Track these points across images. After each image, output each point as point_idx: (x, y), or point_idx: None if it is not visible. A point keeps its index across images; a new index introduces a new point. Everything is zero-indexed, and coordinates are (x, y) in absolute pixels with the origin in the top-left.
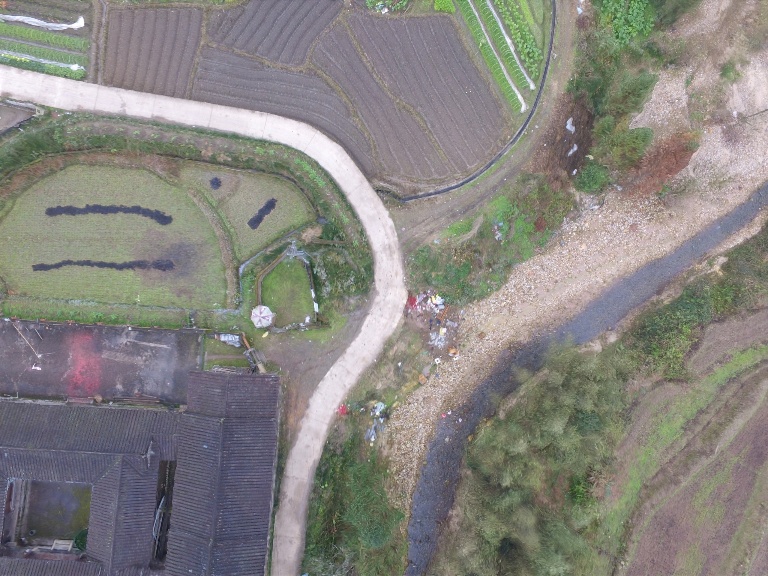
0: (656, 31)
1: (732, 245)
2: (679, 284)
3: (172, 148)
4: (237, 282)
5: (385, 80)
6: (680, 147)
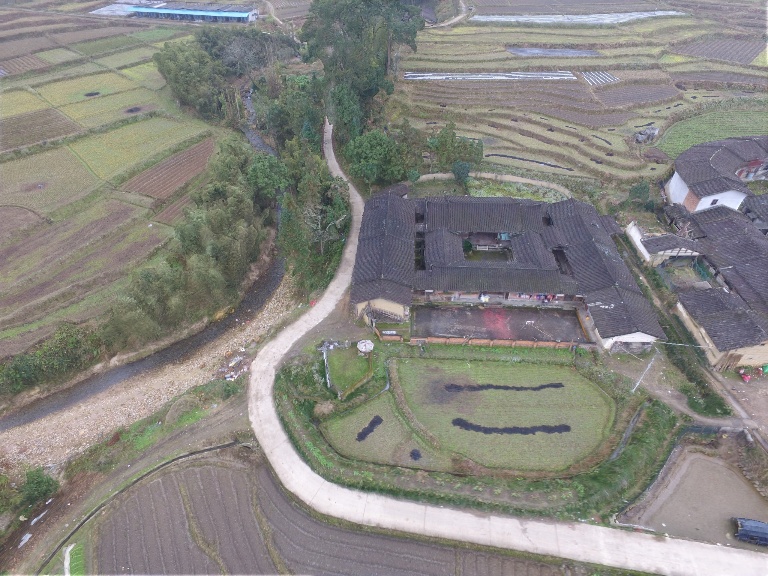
0: None
1: None
2: (15, 405)
3: None
4: None
5: None
6: None
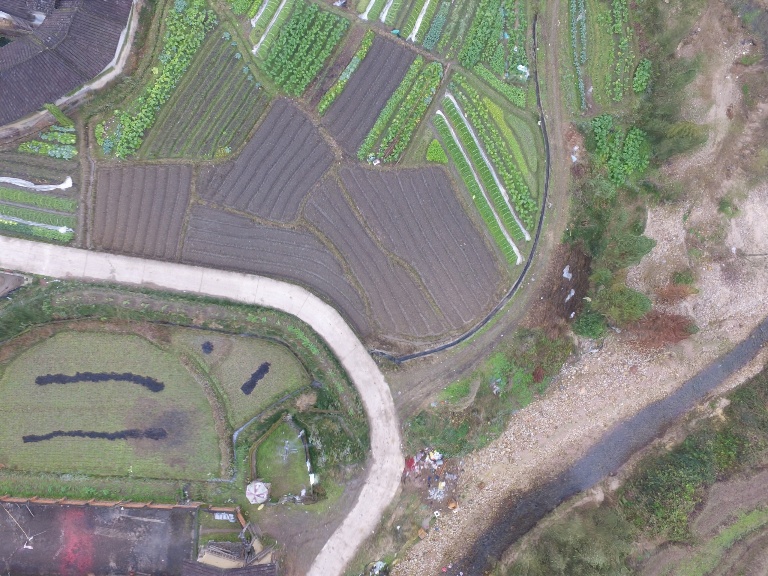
0: (652, 167)
1: (734, 385)
2: (681, 427)
3: (163, 316)
4: (231, 451)
5: (378, 234)
6: (679, 325)
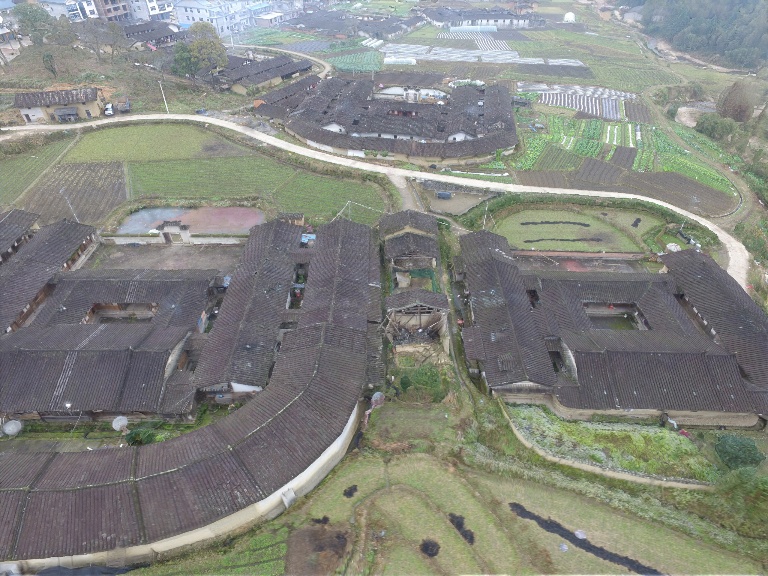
0: None
1: None
2: None
3: (579, 200)
4: None
5: None
6: None
